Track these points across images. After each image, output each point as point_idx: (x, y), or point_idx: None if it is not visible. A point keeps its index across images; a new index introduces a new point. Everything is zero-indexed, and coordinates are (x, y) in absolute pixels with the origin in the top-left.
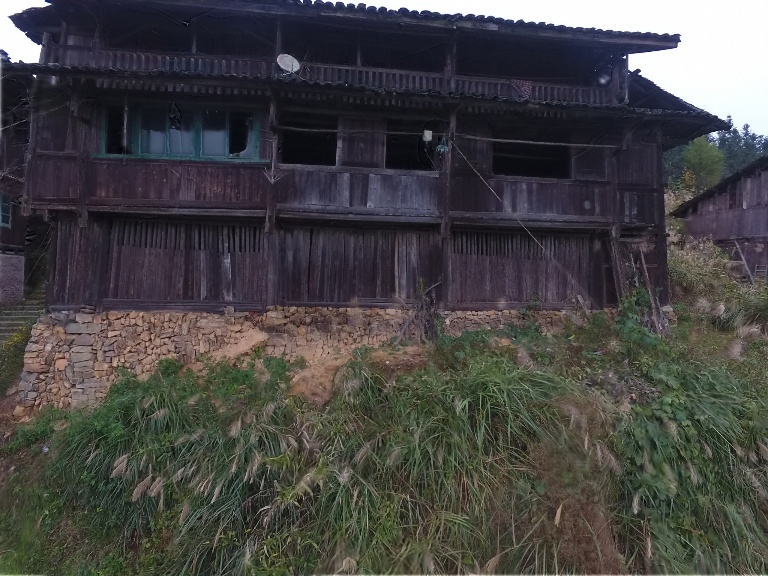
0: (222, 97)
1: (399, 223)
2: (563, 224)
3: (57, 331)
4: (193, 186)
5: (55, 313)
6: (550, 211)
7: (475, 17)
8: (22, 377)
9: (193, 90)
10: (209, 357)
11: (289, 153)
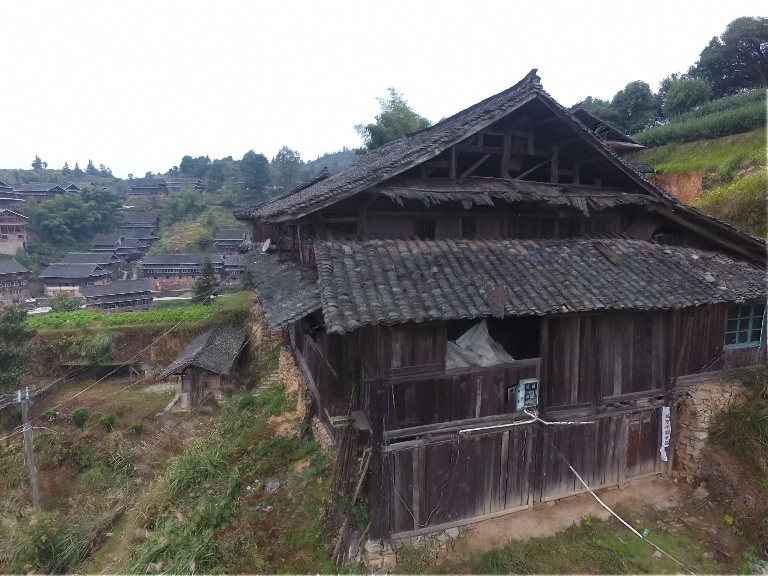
0: None
1: None
2: None
3: None
4: None
5: None
6: None
7: (258, 216)
8: None
9: None
10: None
11: None
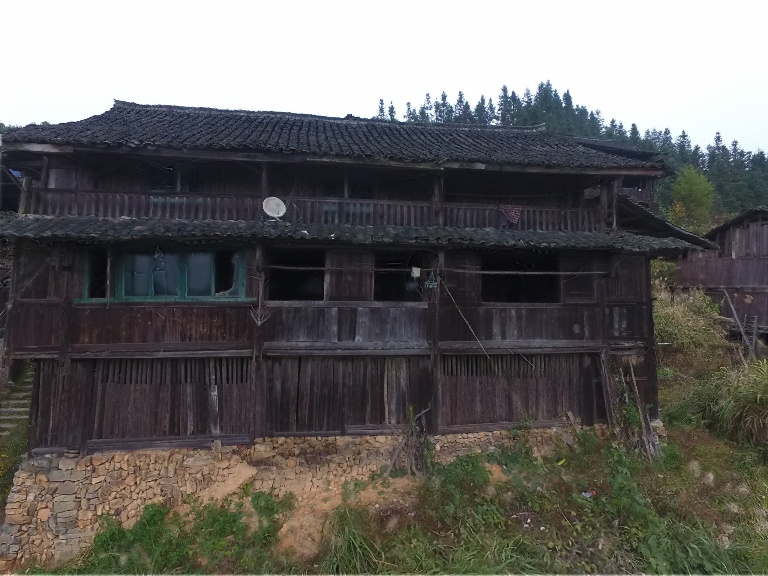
0: (207, 245)
1: (388, 355)
2: (553, 350)
3: (40, 480)
4: (178, 328)
5: (37, 461)
6: (539, 337)
7: (462, 159)
8: (4, 530)
9: None
10: (196, 498)
11: (276, 286)
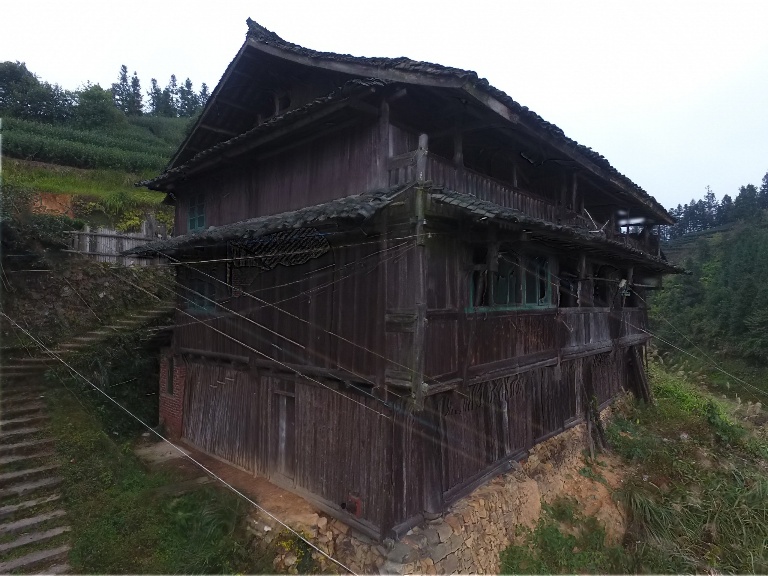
0: None
1: None
2: (639, 341)
3: (428, 566)
4: (523, 339)
5: (421, 541)
6: (635, 332)
7: None
8: None
9: (563, 244)
10: (521, 527)
11: None
